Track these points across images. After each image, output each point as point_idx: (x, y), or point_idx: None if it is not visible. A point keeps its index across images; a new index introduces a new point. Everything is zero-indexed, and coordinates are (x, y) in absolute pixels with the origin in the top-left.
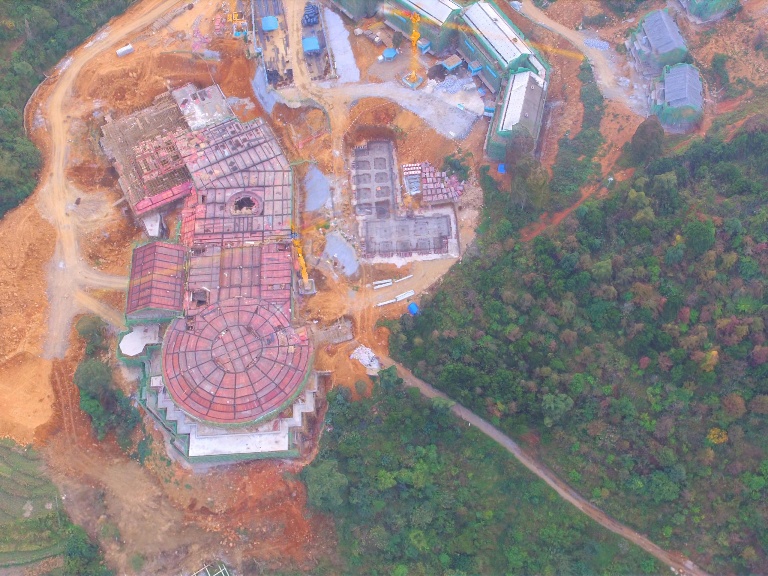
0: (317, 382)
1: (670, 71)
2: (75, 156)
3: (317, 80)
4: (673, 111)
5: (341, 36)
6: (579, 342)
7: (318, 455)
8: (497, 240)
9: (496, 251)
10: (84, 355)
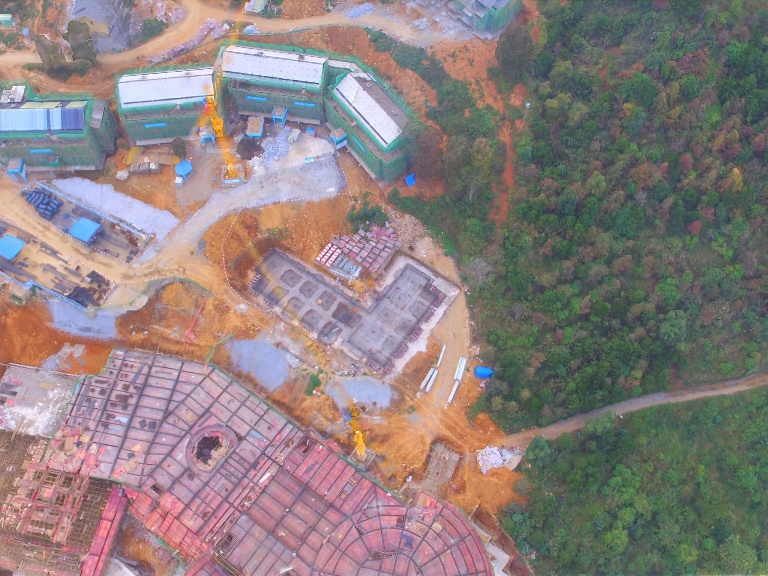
0: (479, 529)
1: None
2: None
3: (134, 258)
4: (502, 12)
5: (105, 195)
6: None
7: None
8: (483, 243)
9: (497, 252)
10: None
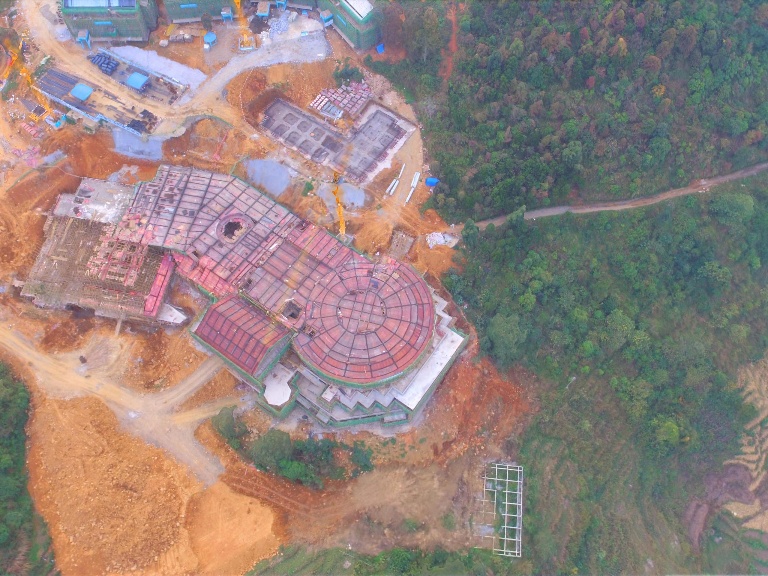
0: None
1: None
2: (32, 332)
3: (174, 102)
4: None
5: (151, 58)
6: None
7: (477, 328)
8: (433, 92)
9: (443, 97)
10: (236, 453)
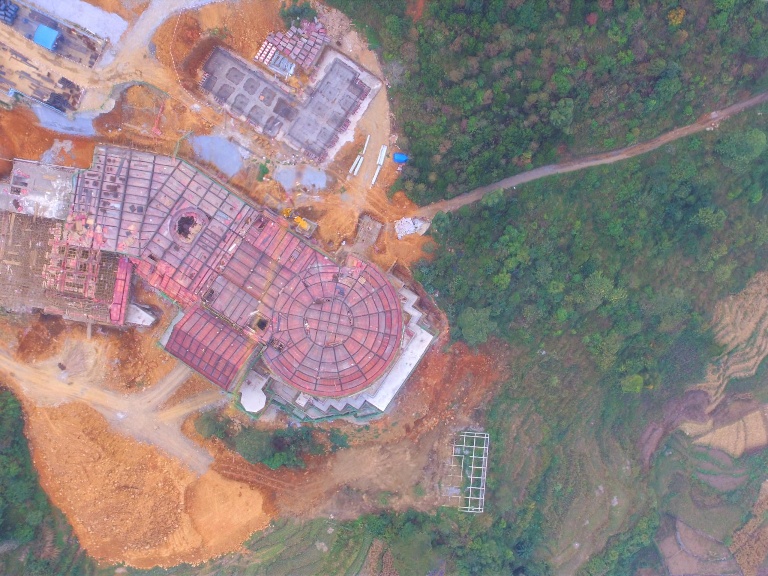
0: (396, 278)
1: None
2: (6, 343)
3: (95, 63)
4: None
5: None
6: (533, 52)
7: (448, 316)
8: (400, 40)
9: (411, 51)
10: (222, 442)
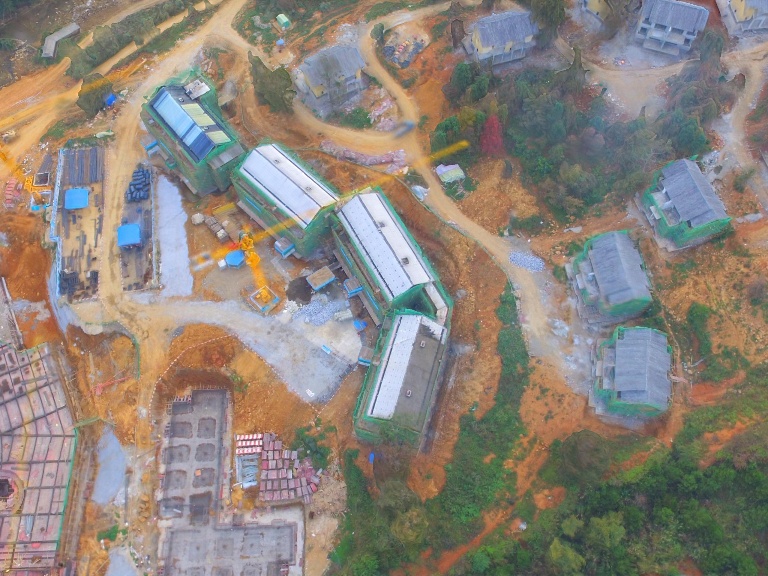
0: None
1: (624, 335)
2: None
3: (131, 290)
4: (625, 406)
5: (175, 221)
6: None
7: None
8: None
9: None
10: None
